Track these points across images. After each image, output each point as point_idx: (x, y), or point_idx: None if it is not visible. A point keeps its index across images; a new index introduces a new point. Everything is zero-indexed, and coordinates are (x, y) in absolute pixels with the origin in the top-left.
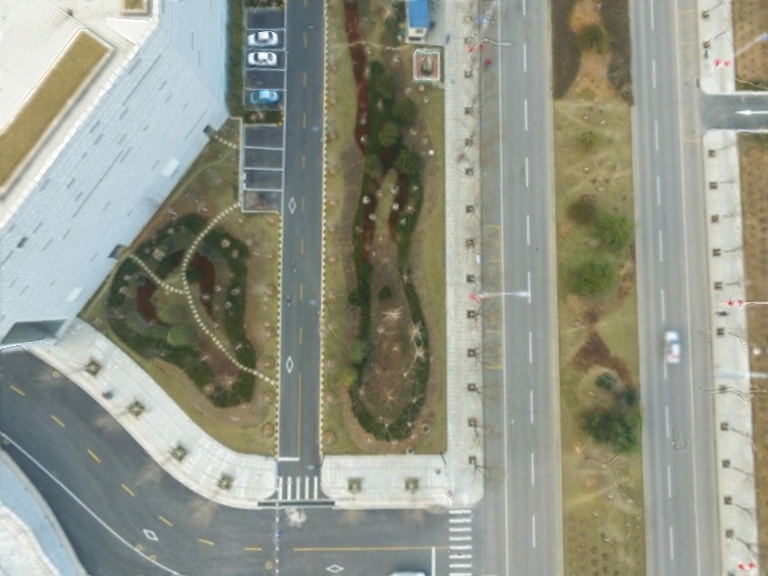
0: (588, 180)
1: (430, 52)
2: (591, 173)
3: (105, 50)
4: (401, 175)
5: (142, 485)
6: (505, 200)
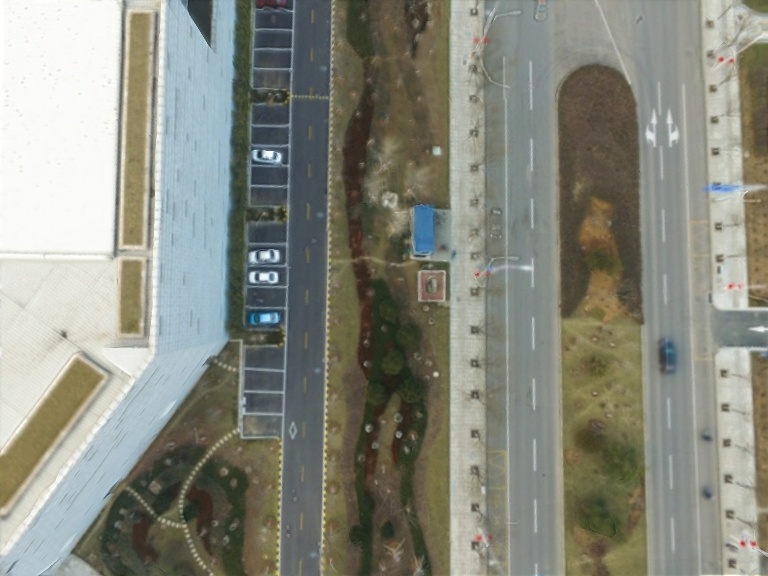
0: (597, 404)
1: (435, 270)
2: (600, 397)
3: (100, 376)
4: (405, 403)
5: None
6: (511, 423)
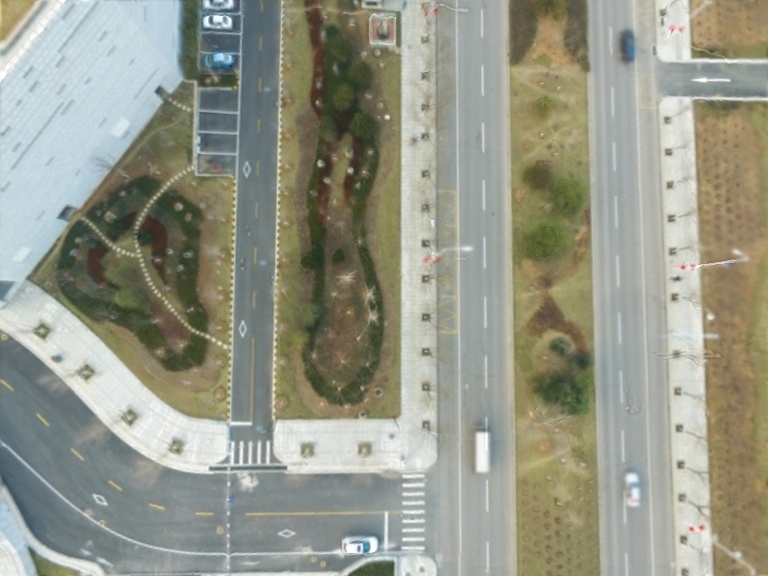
0: (544, 146)
1: (386, 17)
2: (547, 139)
3: None
4: (356, 139)
5: (92, 449)
6: (461, 165)
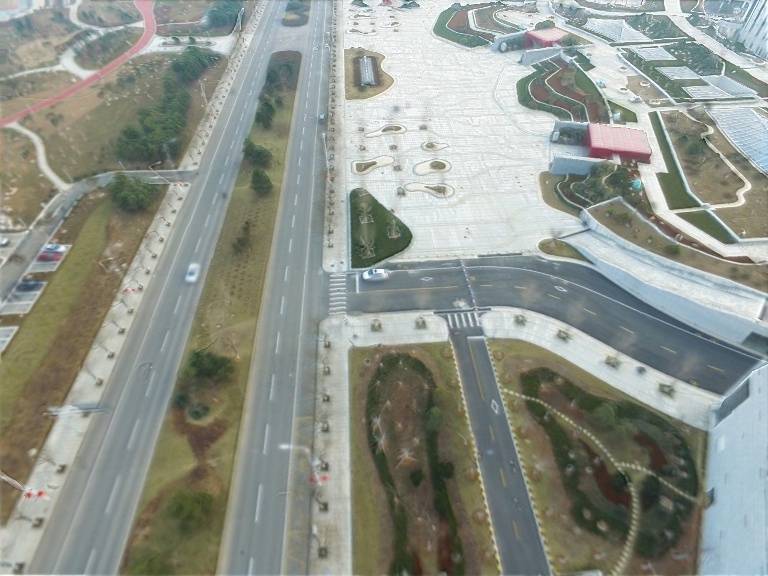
0: None
1: None
2: None
3: None
4: None
5: (581, 315)
6: None
